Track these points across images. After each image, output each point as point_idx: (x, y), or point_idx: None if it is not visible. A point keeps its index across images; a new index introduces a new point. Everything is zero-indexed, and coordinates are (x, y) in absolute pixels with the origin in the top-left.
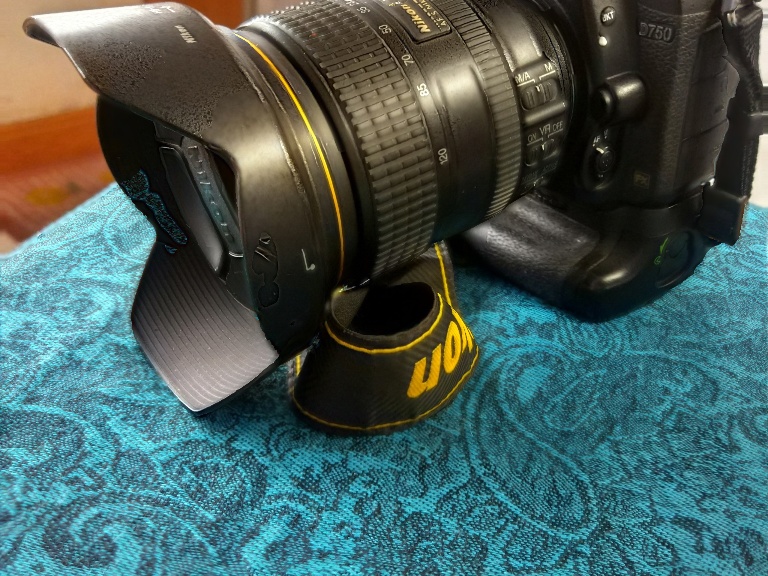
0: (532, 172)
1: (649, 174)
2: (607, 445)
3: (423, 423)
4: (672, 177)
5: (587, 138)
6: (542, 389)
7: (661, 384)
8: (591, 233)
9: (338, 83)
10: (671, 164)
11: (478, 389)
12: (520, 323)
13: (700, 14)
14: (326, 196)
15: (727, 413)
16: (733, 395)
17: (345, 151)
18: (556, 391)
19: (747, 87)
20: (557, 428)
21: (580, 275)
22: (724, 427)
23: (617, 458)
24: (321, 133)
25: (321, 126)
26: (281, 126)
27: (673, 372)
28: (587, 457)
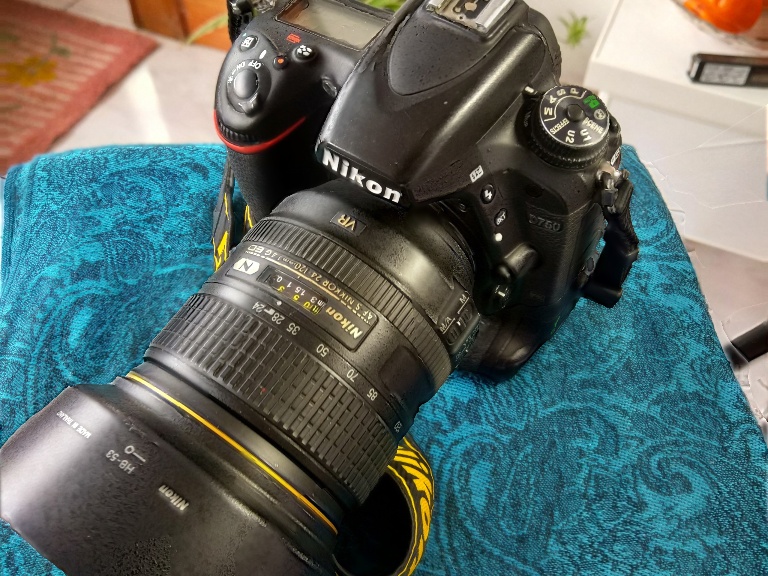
0: None
1: (544, 295)
2: (554, 539)
3: None
4: (563, 290)
5: (490, 290)
6: (490, 490)
7: (576, 445)
8: (493, 319)
9: (305, 438)
10: (562, 286)
11: (442, 511)
12: (449, 409)
13: (583, 207)
14: (324, 532)
15: (630, 464)
16: (630, 439)
17: (328, 487)
18: (501, 488)
19: (625, 242)
20: (514, 534)
21: (492, 361)
22: (631, 482)
23: (565, 551)
24: (306, 490)
25: (304, 484)
26: (285, 532)
27: (581, 425)
28: (544, 561)
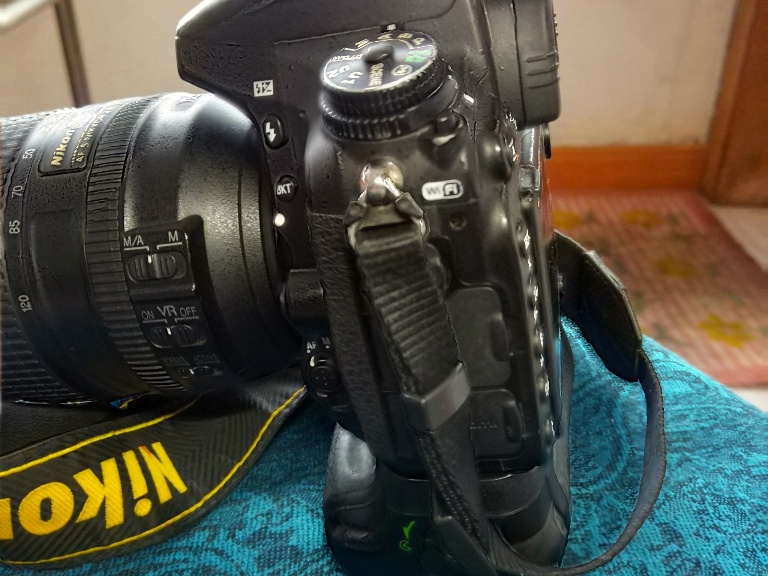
0: (175, 356)
1: None
2: None
3: (22, 571)
4: (385, 437)
5: None
6: None
7: None
8: None
9: None
10: (375, 418)
11: (111, 572)
12: (272, 530)
13: (337, 217)
14: None
15: None
16: None
17: None
18: None
19: (390, 349)
20: None
21: (330, 510)
22: None
23: None
24: None
25: None
26: None
27: None
28: None
